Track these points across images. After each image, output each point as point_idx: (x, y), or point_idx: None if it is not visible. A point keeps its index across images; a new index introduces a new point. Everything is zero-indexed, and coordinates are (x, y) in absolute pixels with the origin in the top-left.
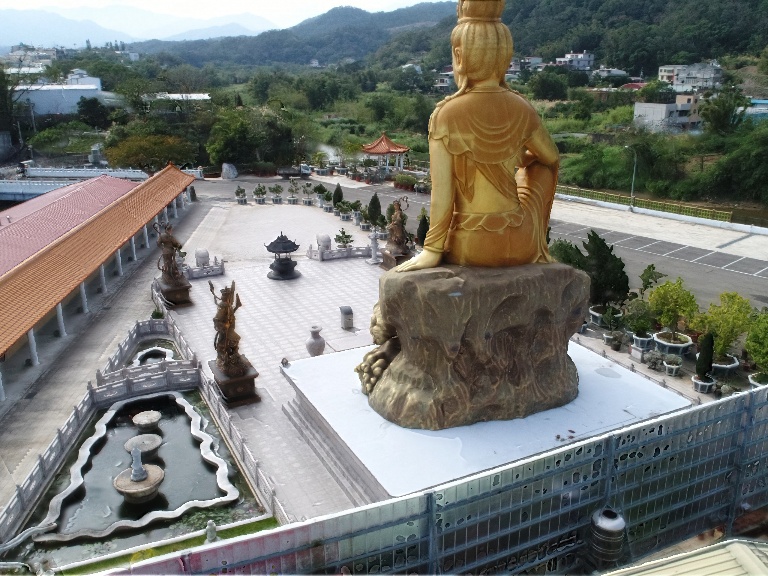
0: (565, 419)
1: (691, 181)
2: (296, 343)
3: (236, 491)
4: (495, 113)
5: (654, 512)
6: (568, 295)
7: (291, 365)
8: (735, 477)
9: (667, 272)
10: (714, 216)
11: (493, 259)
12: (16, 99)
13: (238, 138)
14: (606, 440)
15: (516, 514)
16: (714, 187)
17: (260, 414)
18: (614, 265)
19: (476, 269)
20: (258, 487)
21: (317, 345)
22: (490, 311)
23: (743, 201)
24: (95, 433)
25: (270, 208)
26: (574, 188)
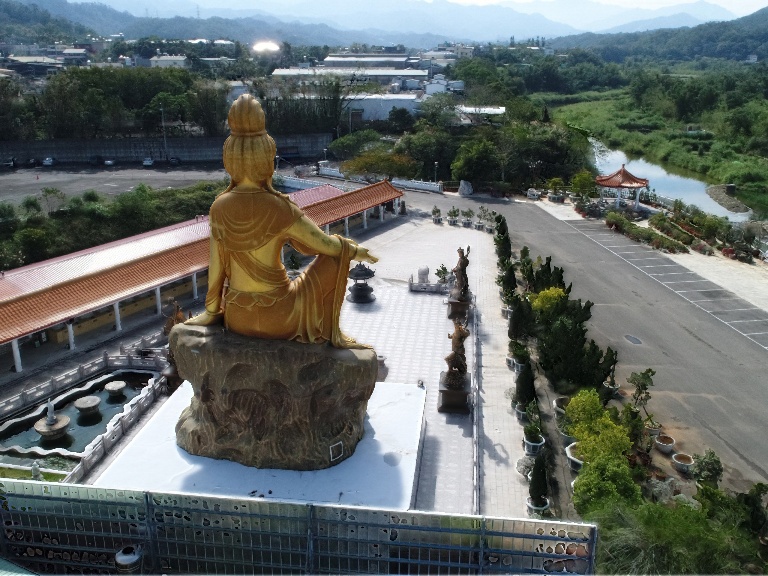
0: (285, 481)
1: None
2: None
3: None
4: (242, 211)
5: (217, 573)
6: (313, 375)
7: None
8: None
9: (753, 383)
10: None
11: (245, 329)
12: (345, 107)
13: (476, 158)
14: None
15: (70, 521)
16: None
17: None
18: (578, 359)
19: (229, 335)
20: None
21: None
22: (224, 371)
23: None
24: (83, 386)
25: (452, 230)
26: None
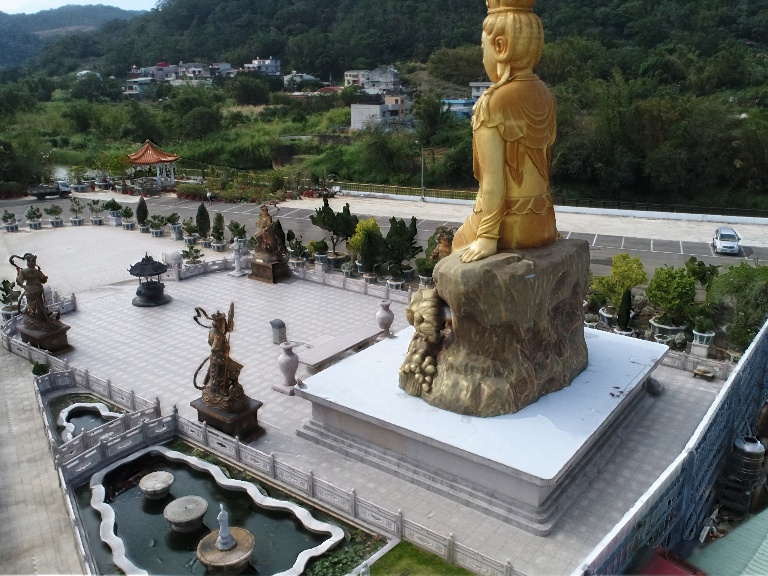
0: (600, 379)
1: None
2: None
3: (337, 528)
4: (538, 100)
5: None
6: None
7: (307, 385)
8: (758, 394)
9: None
10: None
11: (538, 240)
12: None
13: None
14: (734, 378)
15: (704, 458)
16: (448, 176)
17: (279, 446)
18: None
19: (529, 251)
20: (357, 517)
21: (294, 362)
22: (551, 289)
23: (473, 187)
24: (102, 516)
25: (54, 232)
26: (365, 184)
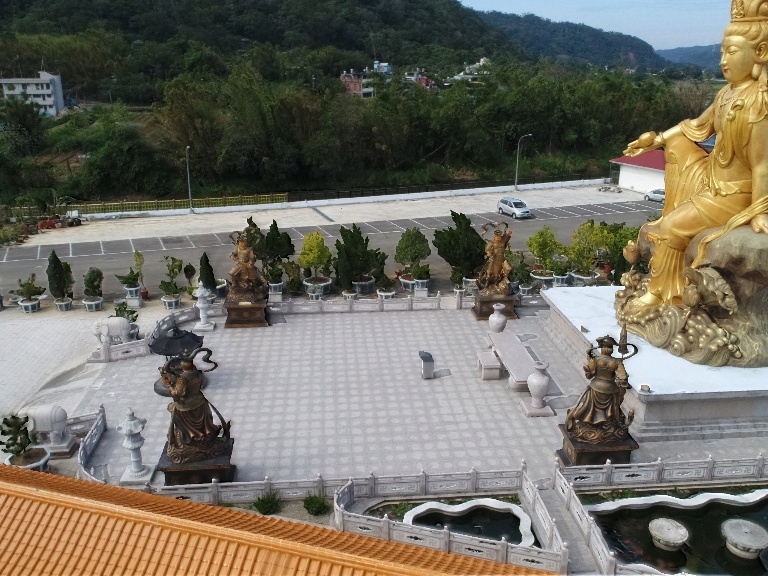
0: None
1: (70, 185)
2: (457, 411)
3: None
4: None
5: None
6: None
7: None
8: None
9: (374, 245)
10: (273, 200)
11: None
12: None
13: None
14: None
15: None
16: (97, 187)
17: (651, 456)
18: None
19: None
20: None
21: None
22: None
23: (128, 195)
24: None
25: None
26: (113, 203)
